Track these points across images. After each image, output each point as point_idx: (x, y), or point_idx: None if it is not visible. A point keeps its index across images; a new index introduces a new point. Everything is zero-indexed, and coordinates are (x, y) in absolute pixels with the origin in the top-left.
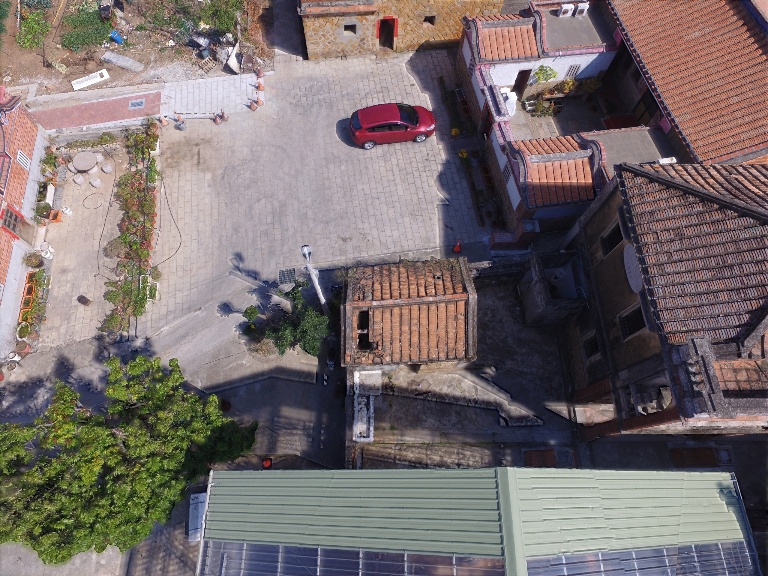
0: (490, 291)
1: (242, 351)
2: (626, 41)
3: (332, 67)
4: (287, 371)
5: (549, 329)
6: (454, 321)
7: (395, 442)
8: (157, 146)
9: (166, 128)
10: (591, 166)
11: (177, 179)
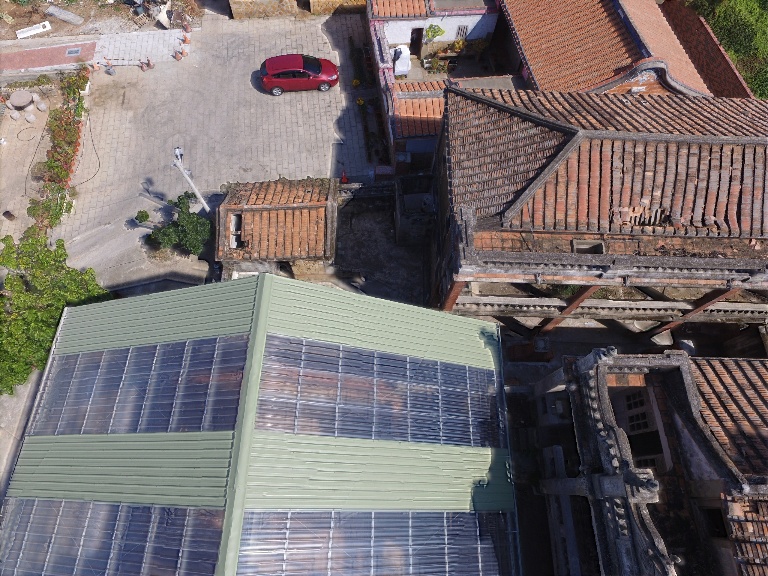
0: (370, 216)
1: (142, 258)
2: (501, 3)
3: (254, 26)
4: (180, 275)
5: (417, 248)
6: (315, 225)
7: None
8: (87, 87)
9: (97, 73)
10: None
11: (102, 116)
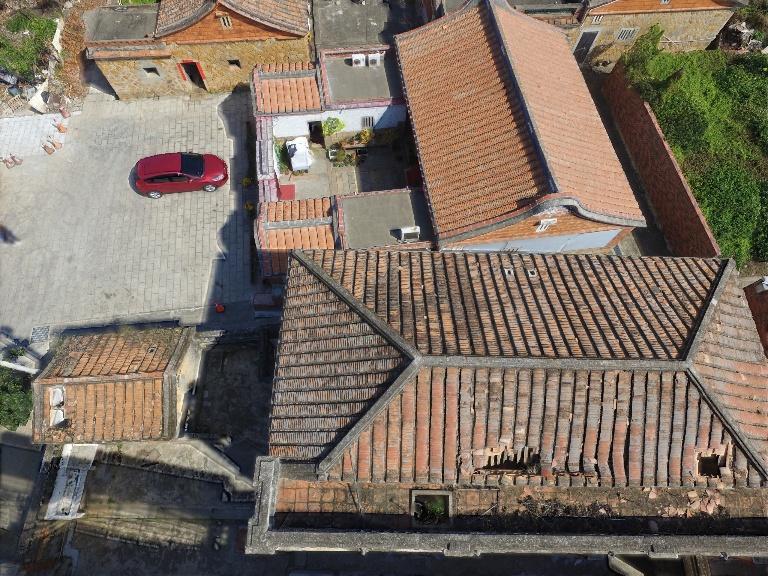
0: (246, 355)
1: None
2: (405, 97)
3: (142, 108)
4: (14, 438)
5: None
6: (151, 400)
7: (109, 517)
8: None
9: None
10: (333, 233)
11: None
